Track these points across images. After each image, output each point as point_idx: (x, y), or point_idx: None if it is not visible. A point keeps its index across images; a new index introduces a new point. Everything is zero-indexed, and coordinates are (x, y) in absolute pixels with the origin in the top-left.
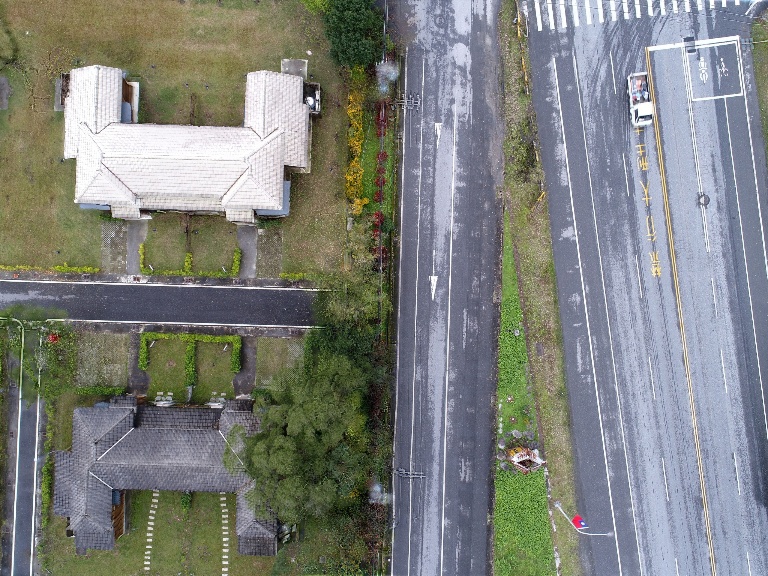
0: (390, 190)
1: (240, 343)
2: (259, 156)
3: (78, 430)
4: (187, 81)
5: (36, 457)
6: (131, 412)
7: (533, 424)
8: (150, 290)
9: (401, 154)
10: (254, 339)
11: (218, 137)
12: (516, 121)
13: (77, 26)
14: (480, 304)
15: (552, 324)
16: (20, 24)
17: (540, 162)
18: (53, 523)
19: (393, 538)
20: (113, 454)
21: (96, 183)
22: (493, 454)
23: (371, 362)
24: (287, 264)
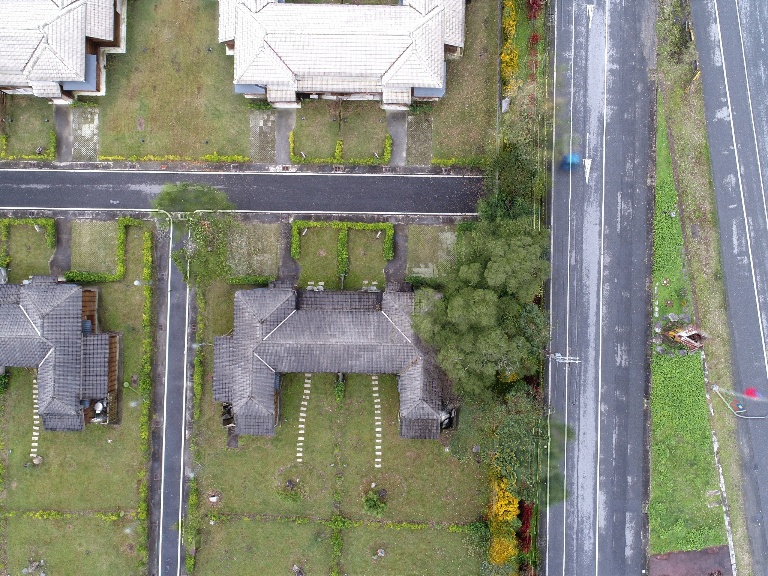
0: (542, 74)
1: (393, 229)
2: (422, 32)
3: (241, 312)
4: None
5: (186, 350)
6: (293, 294)
7: (689, 307)
8: (299, 179)
9: (553, 37)
10: (405, 227)
11: (379, 14)
12: (668, 2)
13: None
14: (634, 187)
15: (707, 206)
16: None
17: (694, 42)
18: (204, 416)
19: (549, 425)
20: (278, 334)
21: (257, 62)
22: (649, 338)
23: (524, 247)
24: (437, 151)
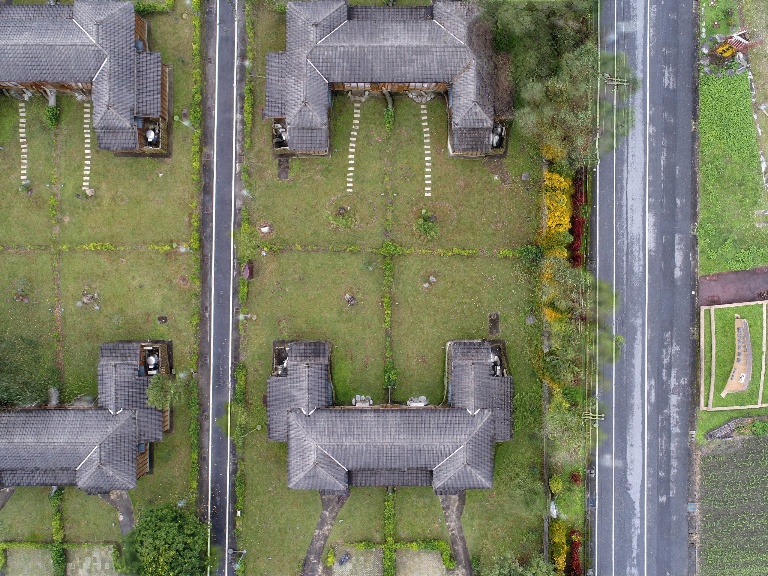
0: None
1: None
2: None
3: (293, 21)
4: None
5: (235, 82)
6: (345, 3)
7: (736, 27)
8: None
9: None
10: None
11: None
12: None
13: None
14: None
15: None
16: None
17: None
18: (254, 148)
19: (597, 148)
20: (332, 39)
21: None
22: (696, 60)
23: None
24: None
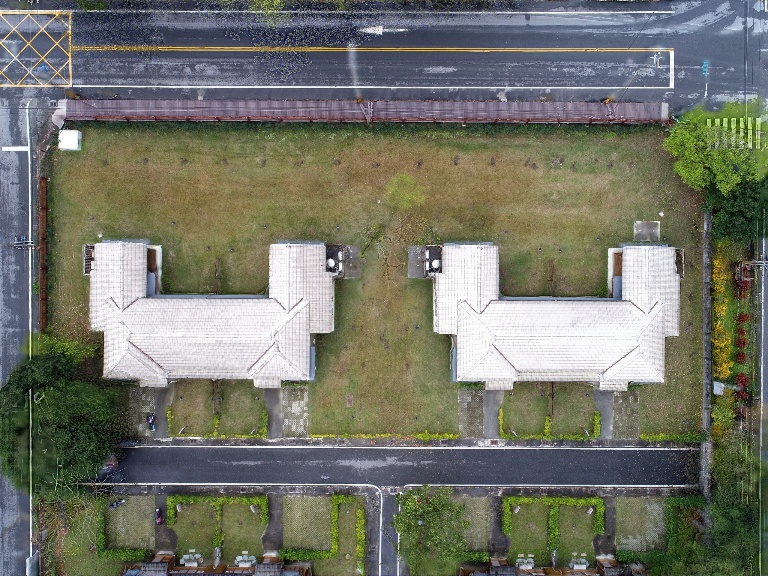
0: (748, 349)
1: (604, 506)
2: (647, 333)
3: None
4: (540, 245)
5: None
6: None
7: None
8: (508, 453)
9: (760, 314)
10: (613, 499)
11: (602, 313)
12: None
13: (429, 193)
14: None
15: None
16: (371, 193)
17: None
18: None
19: None
20: None
21: (484, 363)
22: None
23: (732, 520)
24: (644, 424)
